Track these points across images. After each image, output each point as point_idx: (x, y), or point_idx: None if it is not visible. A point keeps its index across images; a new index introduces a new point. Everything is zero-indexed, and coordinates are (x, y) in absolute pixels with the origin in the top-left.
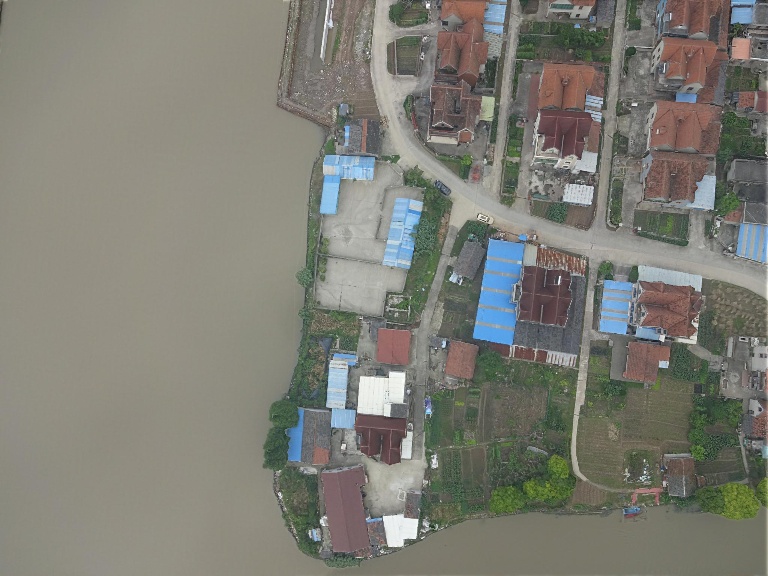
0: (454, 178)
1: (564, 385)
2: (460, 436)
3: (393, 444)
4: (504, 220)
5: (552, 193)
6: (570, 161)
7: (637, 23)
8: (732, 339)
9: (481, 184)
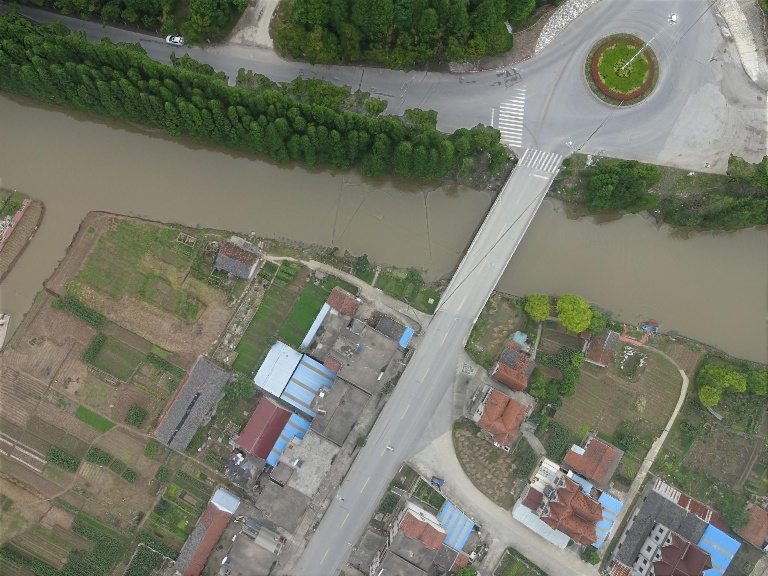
0: None
1: (667, 462)
2: None
3: None
4: None
5: None
6: None
7: None
8: None
9: None
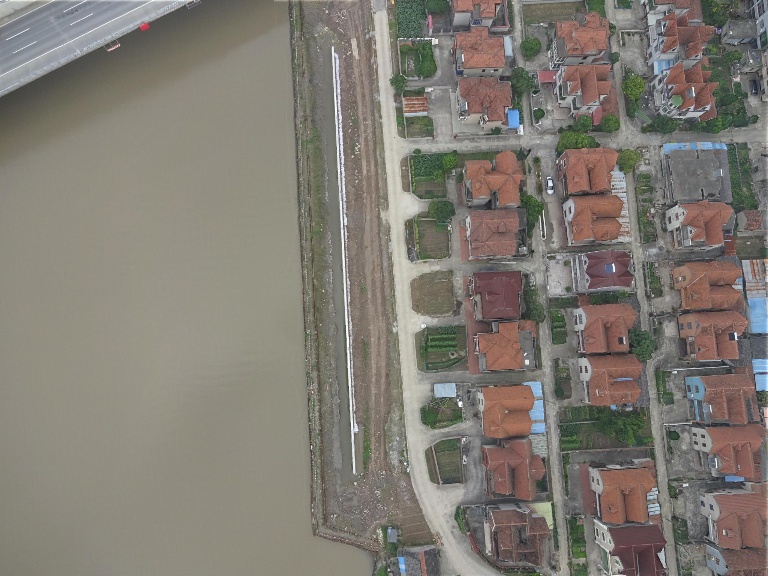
0: None
1: None
2: None
3: None
4: None
5: None
6: None
7: (670, 398)
8: None
9: None
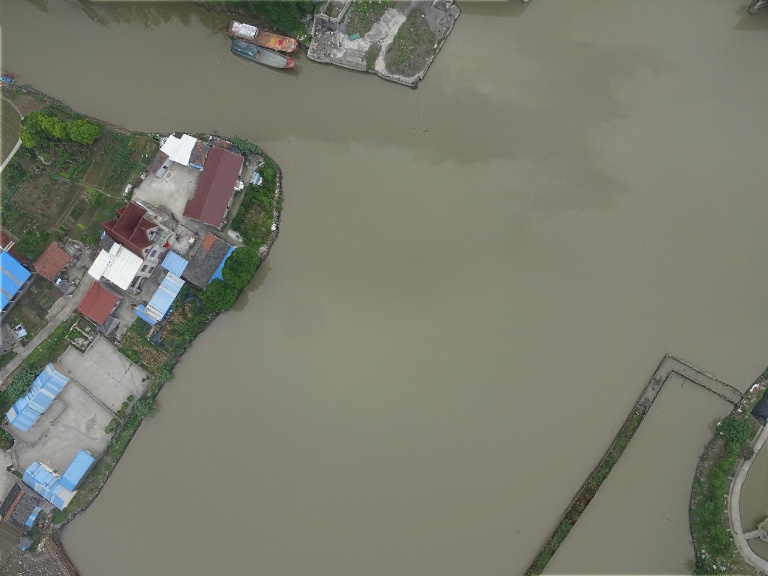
0: None
1: None
2: None
3: None
4: None
5: None
6: None
7: None
8: None
9: None
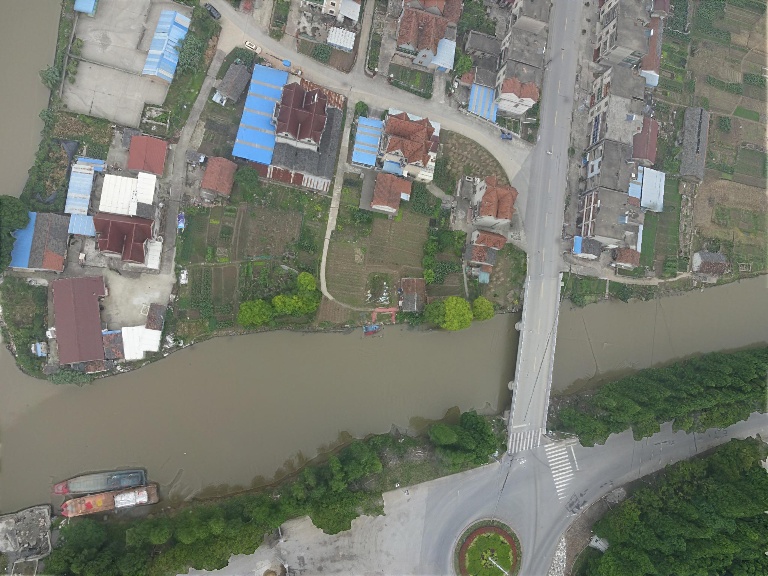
0: (225, 5)
1: (318, 211)
2: (213, 253)
3: (136, 240)
4: (272, 52)
5: (318, 36)
6: (335, 2)
7: None
8: (461, 179)
9: (252, 15)
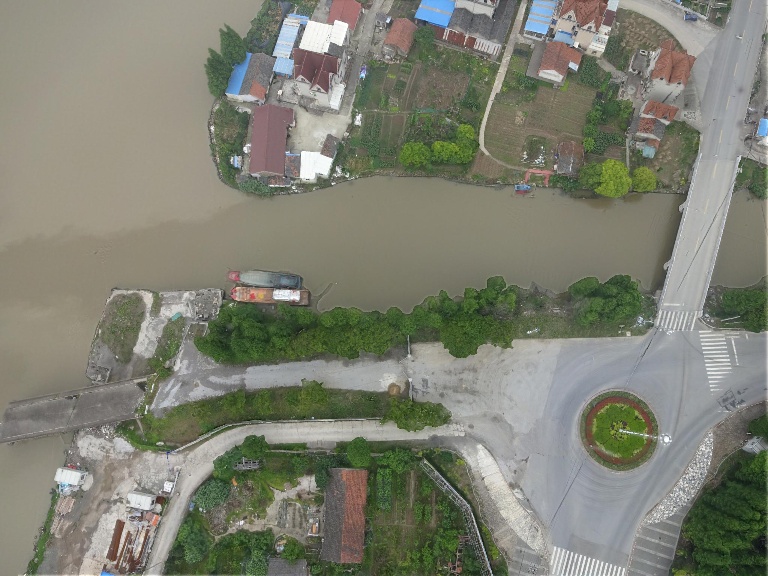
0: None
1: (485, 74)
2: (386, 102)
3: (324, 70)
4: None
5: None
6: None
7: None
8: None
9: None
